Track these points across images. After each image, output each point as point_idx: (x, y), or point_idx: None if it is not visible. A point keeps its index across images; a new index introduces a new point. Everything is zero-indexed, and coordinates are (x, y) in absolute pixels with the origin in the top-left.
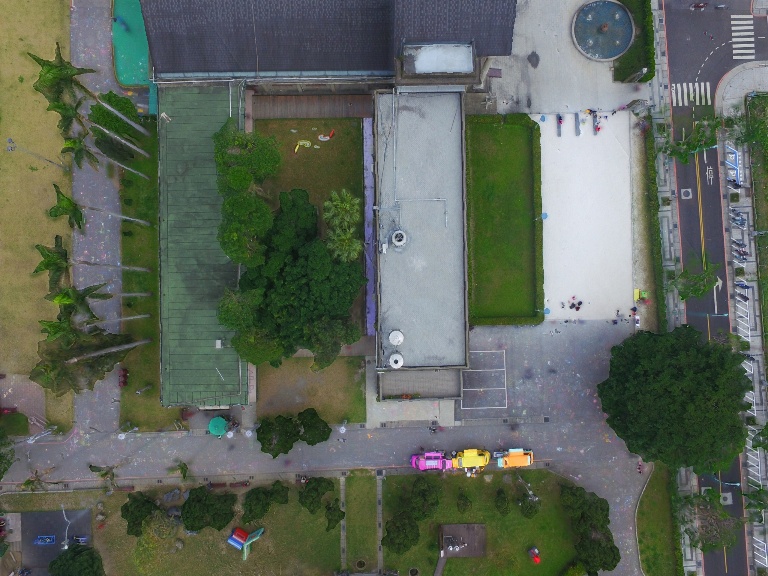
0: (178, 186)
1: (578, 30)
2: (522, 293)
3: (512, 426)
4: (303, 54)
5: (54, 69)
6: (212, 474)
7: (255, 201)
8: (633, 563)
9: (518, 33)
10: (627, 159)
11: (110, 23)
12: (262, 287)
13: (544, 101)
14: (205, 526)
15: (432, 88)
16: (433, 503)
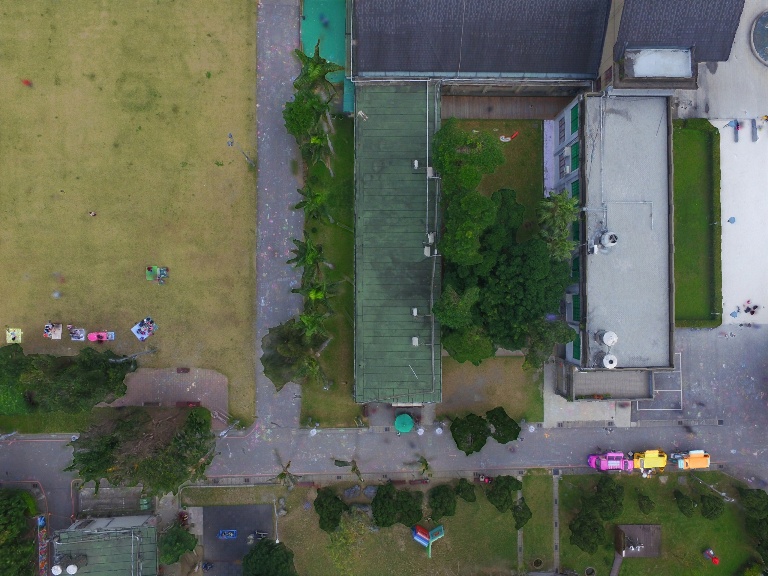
0: (374, 184)
1: (756, 37)
2: (698, 296)
3: (687, 428)
4: (505, 56)
5: (318, 66)
6: (391, 471)
7: (487, 200)
8: None
9: None
10: None
11: (296, 21)
12: (476, 286)
13: (722, 107)
14: None
15: (642, 92)
16: (620, 503)
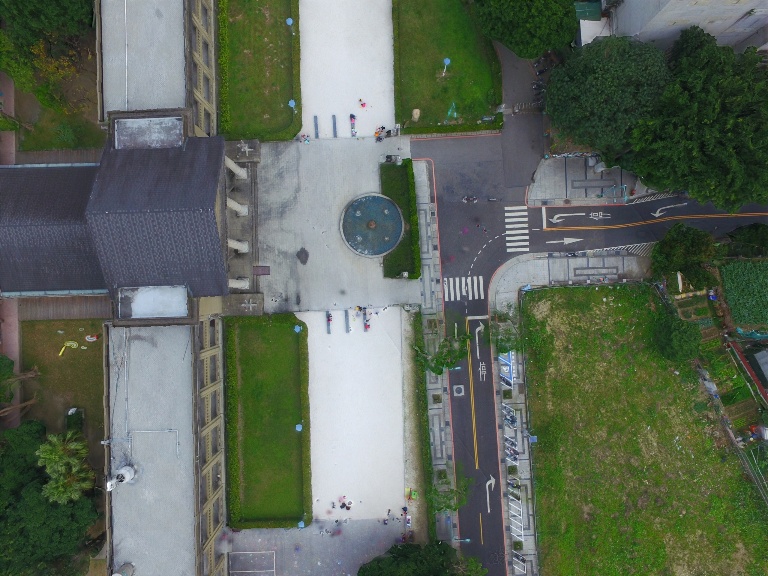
0: None
1: (347, 226)
2: (292, 493)
3: None
4: (43, 276)
5: None
6: None
7: None
8: None
9: (287, 229)
10: (399, 355)
11: None
12: None
13: (313, 298)
14: None
15: None
16: None
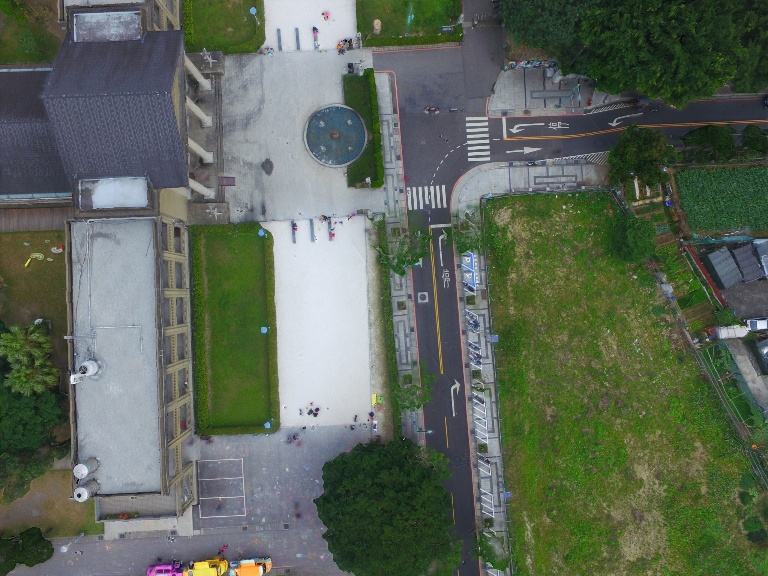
0: None
1: (311, 136)
2: (259, 401)
3: (251, 534)
4: (6, 179)
5: None
6: None
7: None
8: None
9: (251, 140)
10: (363, 264)
11: None
12: None
13: (279, 208)
14: None
15: None
16: None
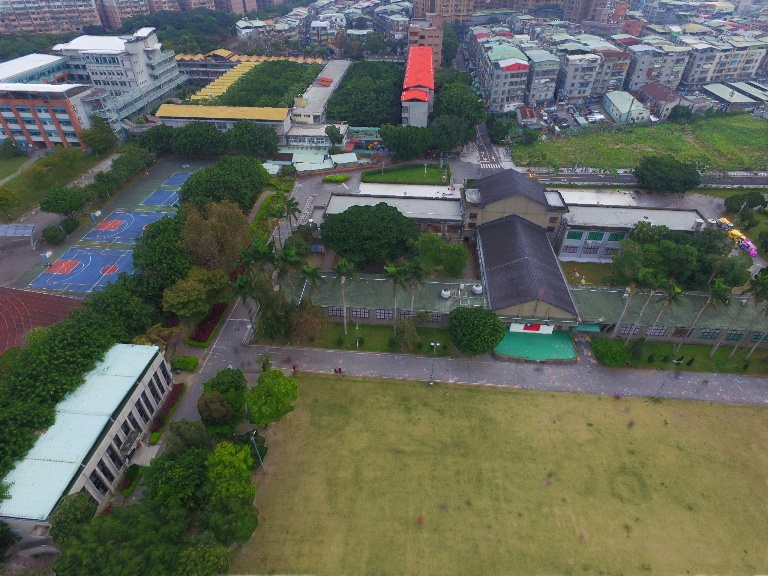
0: (647, 317)
1: None
2: None
3: None
4: None
5: None
6: None
7: None
8: None
9: None
10: None
11: (527, 365)
12: None
13: None
14: None
15: None
16: None
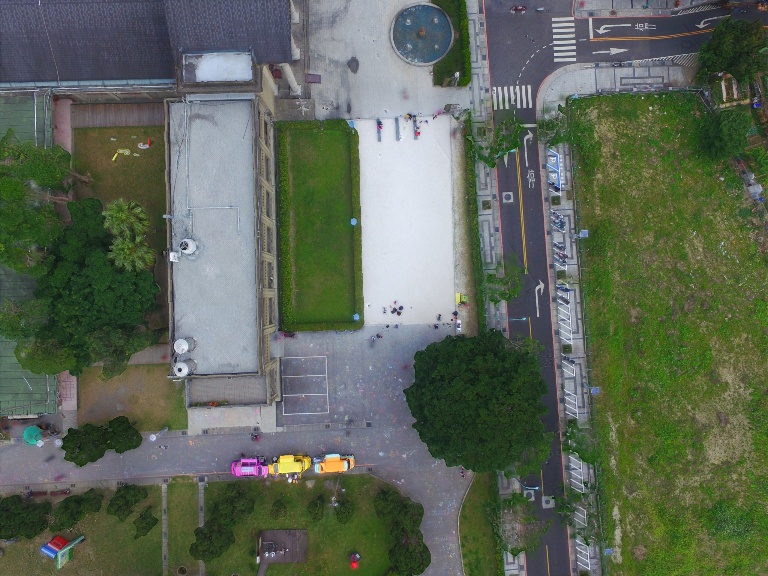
0: None
1: (397, 35)
2: (343, 298)
3: (334, 431)
4: (102, 63)
5: None
6: (33, 482)
7: (24, 212)
8: (456, 567)
9: (337, 38)
10: (448, 163)
11: None
12: (49, 297)
13: (364, 106)
14: (16, 535)
15: (221, 96)
16: (243, 509)
